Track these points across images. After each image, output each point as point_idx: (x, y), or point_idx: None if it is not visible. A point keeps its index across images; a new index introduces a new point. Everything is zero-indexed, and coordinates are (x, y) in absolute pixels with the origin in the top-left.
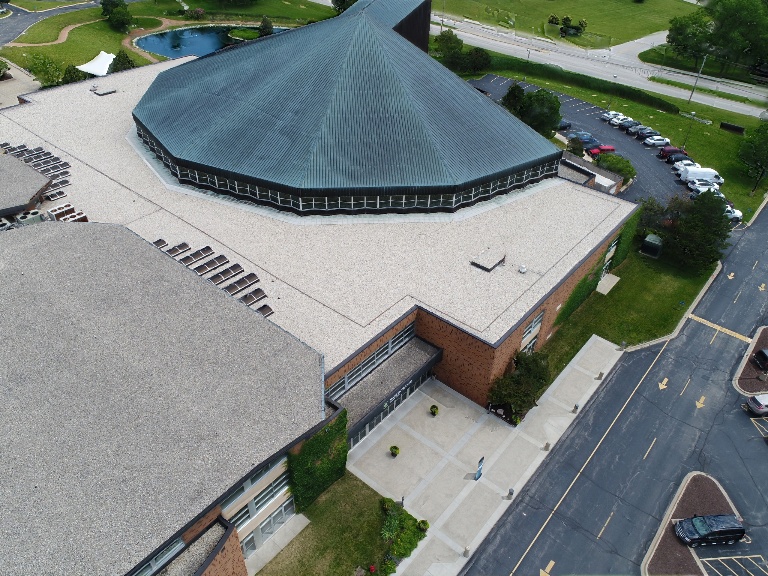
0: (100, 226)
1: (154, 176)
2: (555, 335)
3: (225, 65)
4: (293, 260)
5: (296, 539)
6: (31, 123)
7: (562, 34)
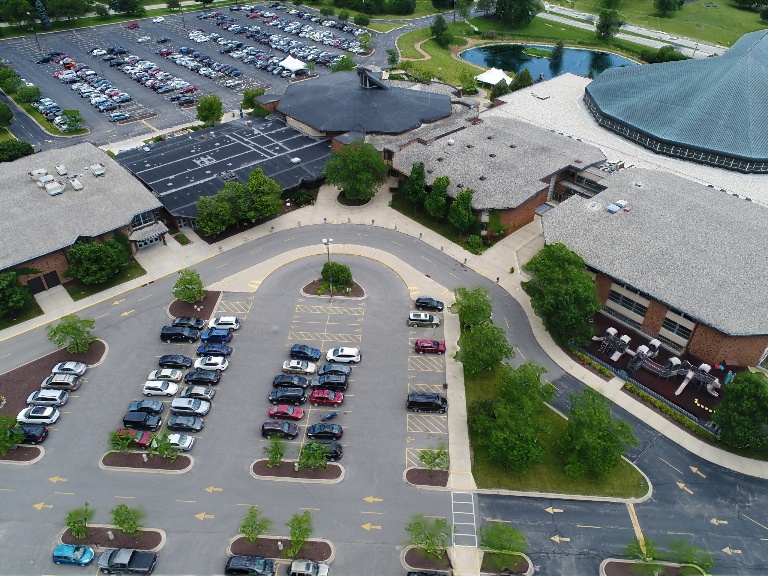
0: (658, 171)
1: (636, 149)
2: None
3: (654, 84)
4: (760, 194)
5: None
6: (524, 116)
7: None
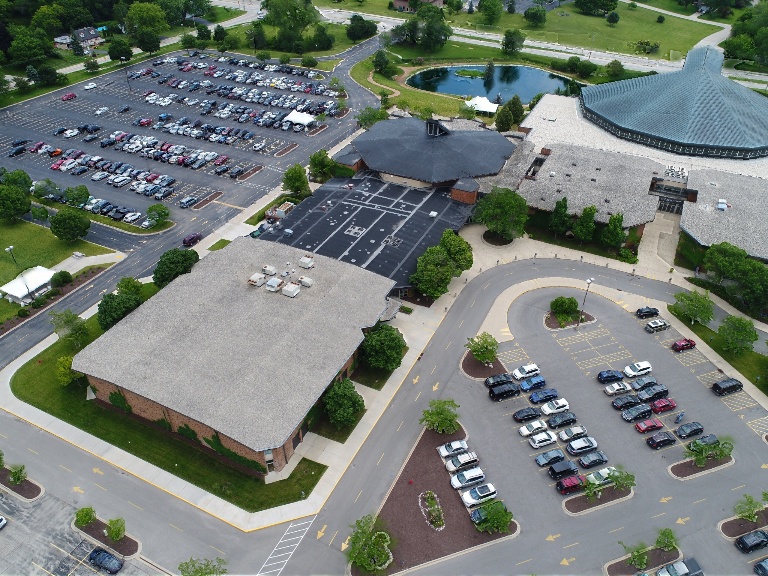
0: None
1: (662, 153)
2: None
3: (647, 99)
4: None
5: None
6: (557, 138)
7: (683, 57)
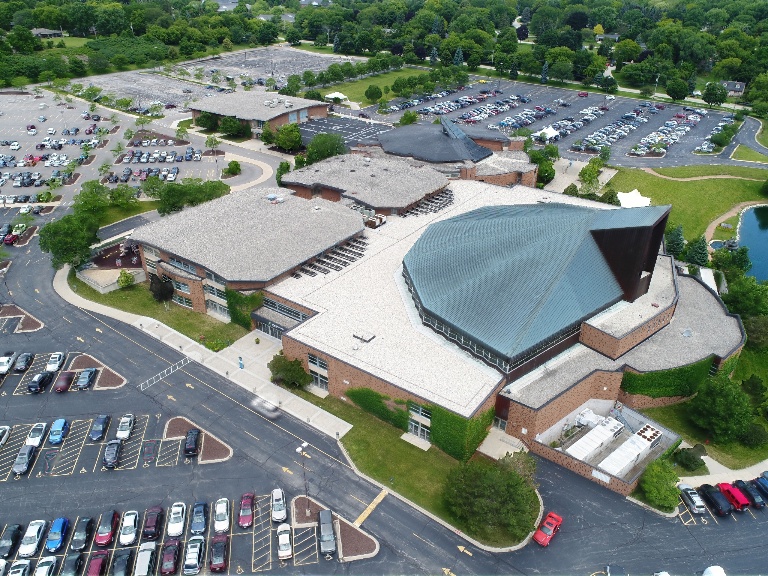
0: None
1: None
2: (348, 404)
3: None
4: None
5: (220, 321)
6: None
7: None
